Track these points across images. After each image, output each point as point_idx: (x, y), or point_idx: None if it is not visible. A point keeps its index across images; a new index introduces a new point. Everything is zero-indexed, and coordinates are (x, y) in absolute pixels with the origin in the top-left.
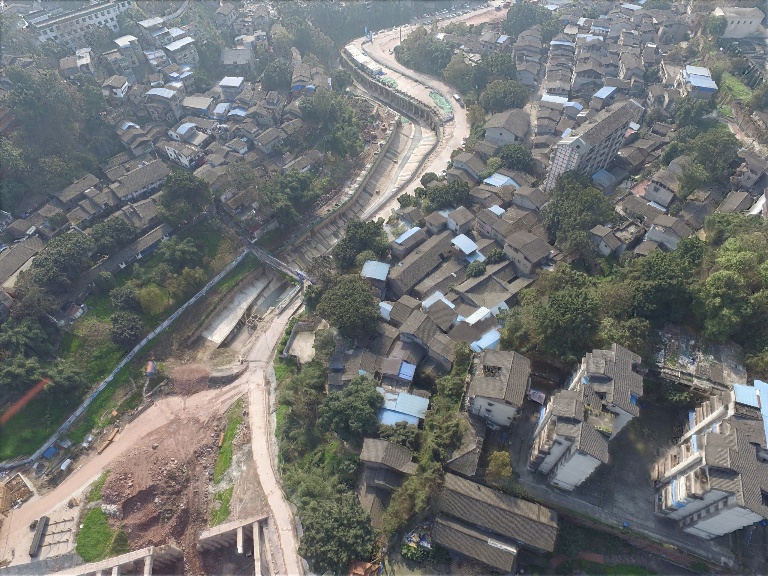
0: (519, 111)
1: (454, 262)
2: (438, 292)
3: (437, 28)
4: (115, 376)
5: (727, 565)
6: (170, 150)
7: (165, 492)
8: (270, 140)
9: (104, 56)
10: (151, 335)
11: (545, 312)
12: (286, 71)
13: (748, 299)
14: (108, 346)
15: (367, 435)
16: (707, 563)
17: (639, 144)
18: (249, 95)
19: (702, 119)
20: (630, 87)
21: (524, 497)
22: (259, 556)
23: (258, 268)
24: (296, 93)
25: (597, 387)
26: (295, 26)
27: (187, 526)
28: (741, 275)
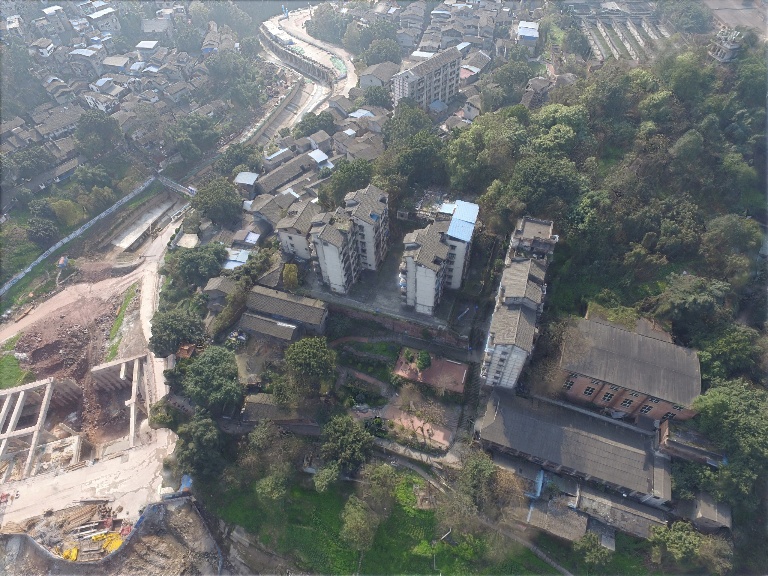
0: (390, 63)
1: (312, 172)
2: (289, 188)
3: (342, 4)
4: (33, 269)
5: (441, 329)
6: (89, 99)
7: (68, 346)
8: (177, 90)
9: (32, 22)
10: (65, 240)
11: (337, 175)
12: (198, 37)
13: (476, 158)
14: (27, 246)
15: (212, 276)
16: (427, 328)
17: (476, 83)
18: (162, 55)
19: (529, 63)
20: (482, 42)
21: (307, 295)
22: (136, 379)
23: (163, 192)
24: (206, 55)
25: (349, 209)
26: (213, 2)
27: (87, 372)
28: (474, 142)
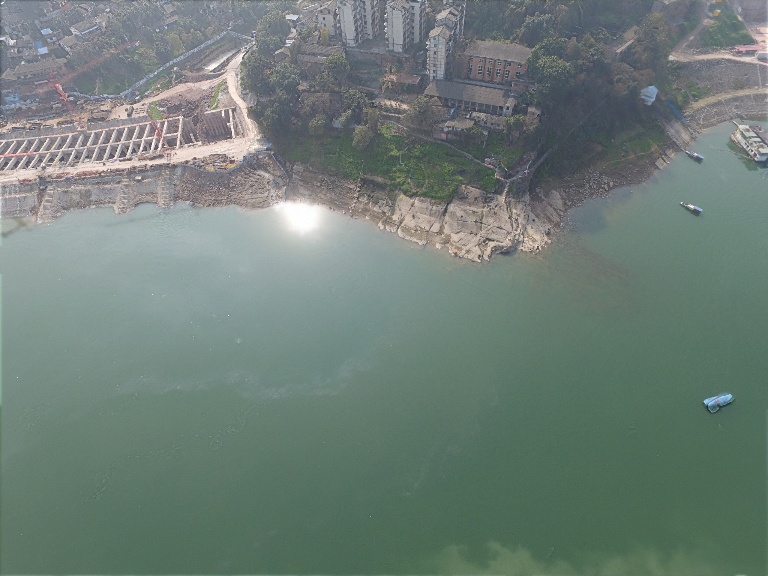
0: None
1: None
2: None
3: None
4: (158, 73)
5: None
6: None
7: (187, 107)
8: None
9: None
10: (175, 60)
11: None
12: None
13: None
14: (153, 61)
15: None
16: (399, 57)
17: None
18: None
19: None
20: None
21: (334, 45)
22: None
23: (232, 42)
24: None
25: None
26: None
27: (198, 123)
28: None
